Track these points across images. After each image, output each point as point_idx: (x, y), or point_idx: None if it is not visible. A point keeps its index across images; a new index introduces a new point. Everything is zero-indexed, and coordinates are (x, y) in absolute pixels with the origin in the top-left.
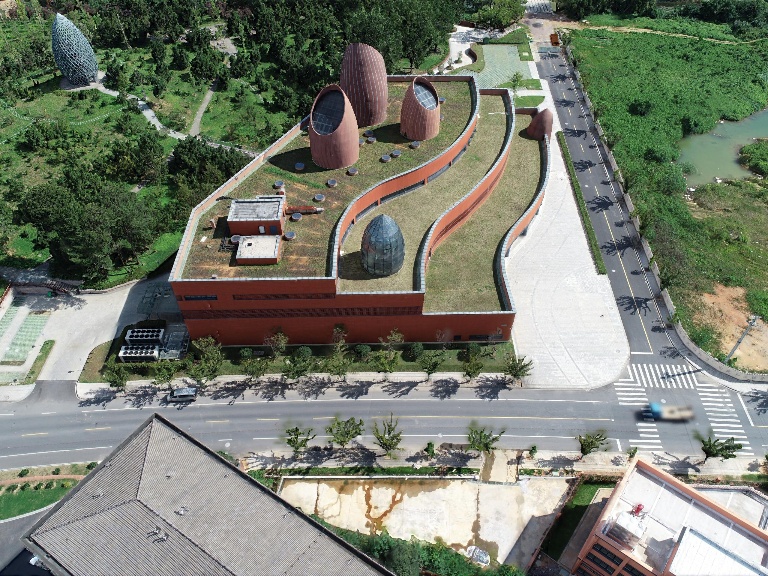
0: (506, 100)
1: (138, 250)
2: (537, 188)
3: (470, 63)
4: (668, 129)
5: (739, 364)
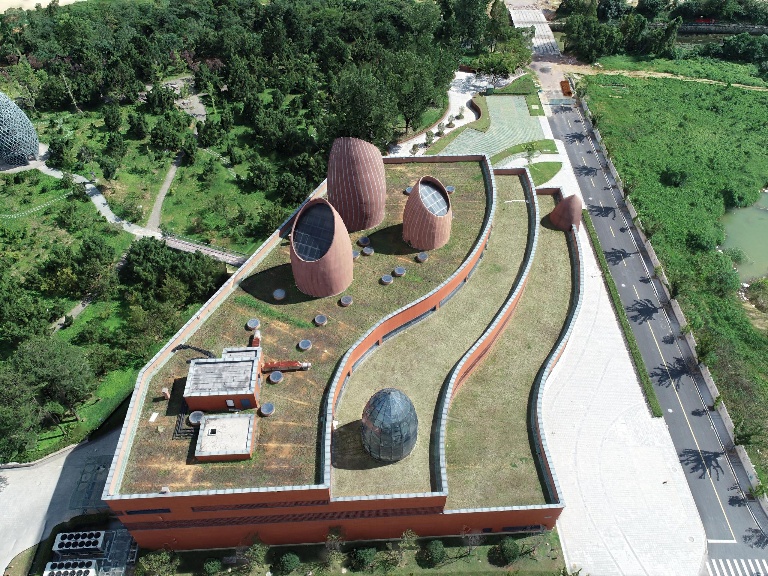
0: (524, 182)
1: (77, 401)
2: (570, 301)
3: (473, 119)
4: (708, 204)
5: None
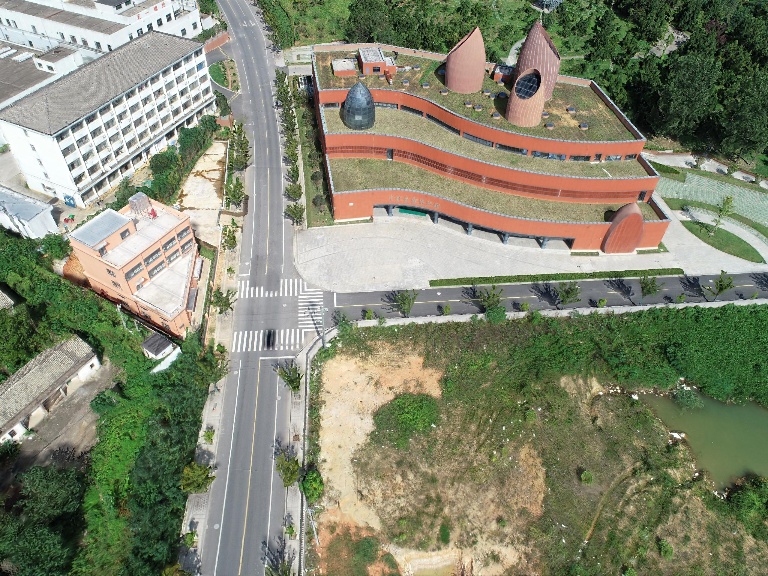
0: None
1: None
2: None
3: None
4: None
5: (329, 365)
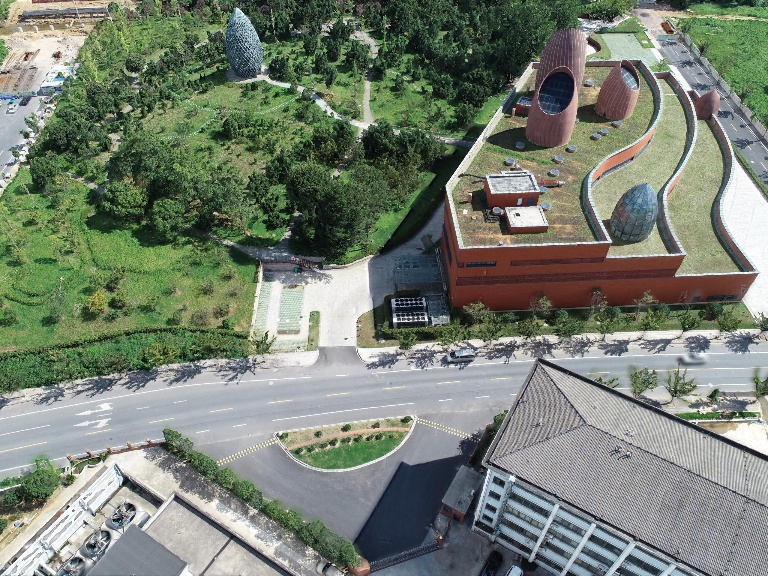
0: (670, 83)
1: None
2: (723, 163)
3: (594, 51)
4: None
5: None
